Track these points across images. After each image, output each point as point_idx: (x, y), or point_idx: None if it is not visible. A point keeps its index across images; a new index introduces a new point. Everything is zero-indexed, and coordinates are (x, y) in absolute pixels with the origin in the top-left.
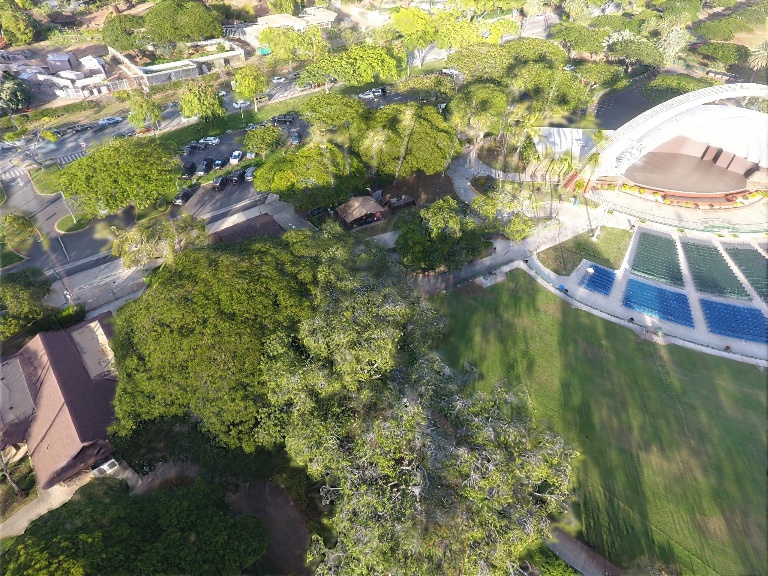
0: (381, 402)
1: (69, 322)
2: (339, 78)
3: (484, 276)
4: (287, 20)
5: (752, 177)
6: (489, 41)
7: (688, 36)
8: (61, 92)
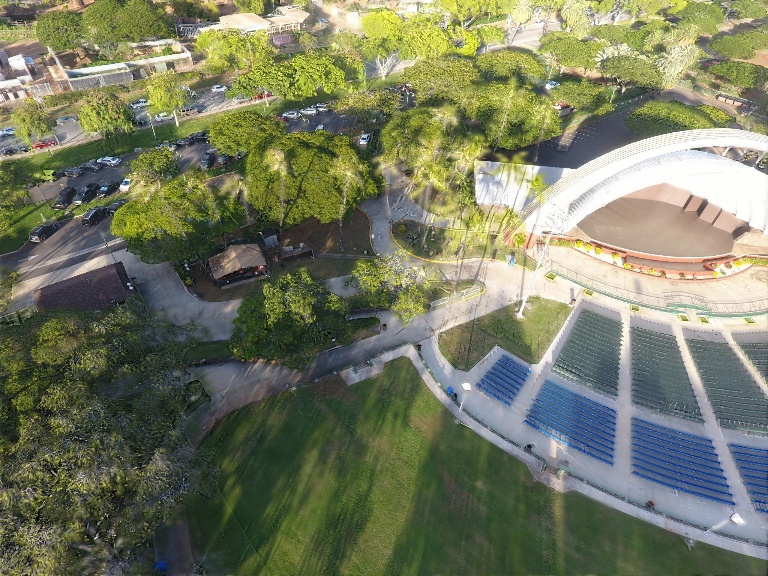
0: None
1: None
2: (274, 91)
3: (356, 366)
4: (249, 20)
5: (741, 238)
6: (463, 52)
7: (698, 53)
8: None
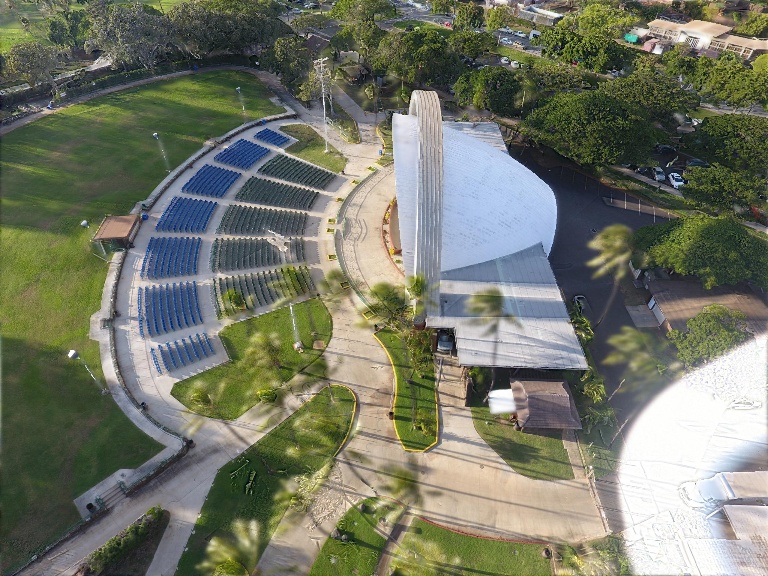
0: None
1: None
2: None
3: (281, 101)
4: (705, 28)
5: None
6: None
7: None
8: (486, 2)
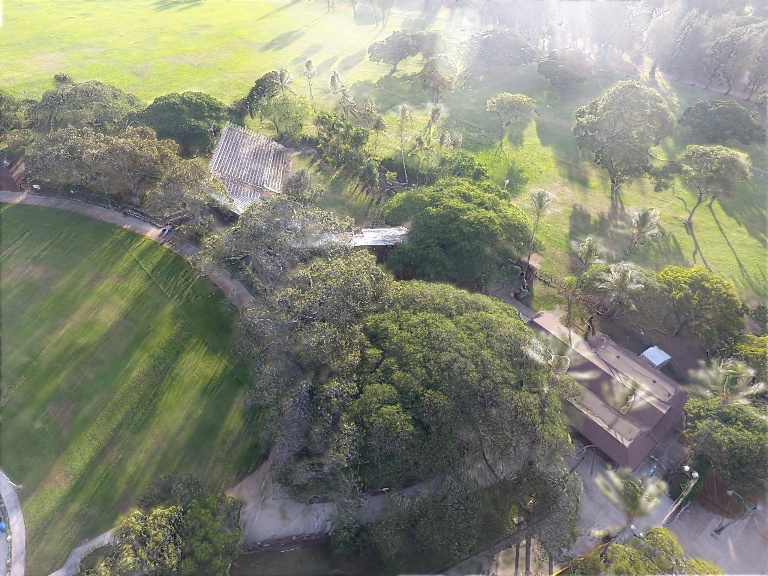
0: (312, 252)
1: (677, 479)
2: None
3: None
4: None
5: None
6: None
7: None
8: None
